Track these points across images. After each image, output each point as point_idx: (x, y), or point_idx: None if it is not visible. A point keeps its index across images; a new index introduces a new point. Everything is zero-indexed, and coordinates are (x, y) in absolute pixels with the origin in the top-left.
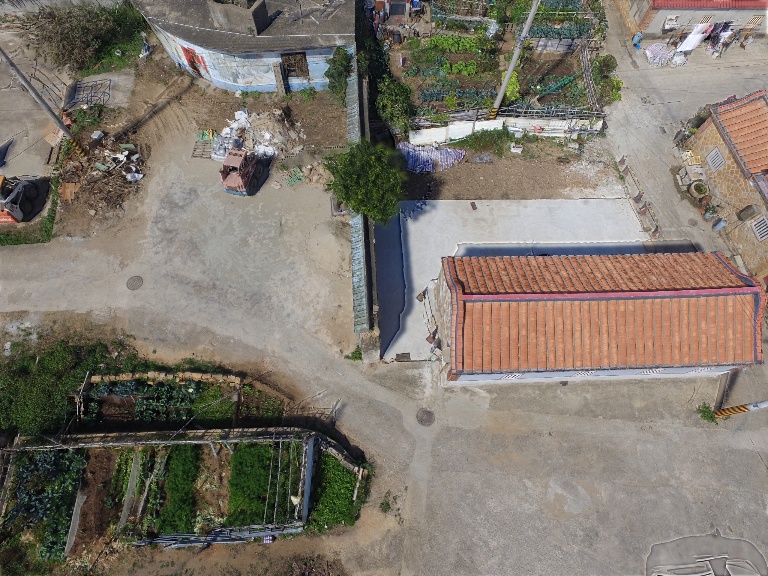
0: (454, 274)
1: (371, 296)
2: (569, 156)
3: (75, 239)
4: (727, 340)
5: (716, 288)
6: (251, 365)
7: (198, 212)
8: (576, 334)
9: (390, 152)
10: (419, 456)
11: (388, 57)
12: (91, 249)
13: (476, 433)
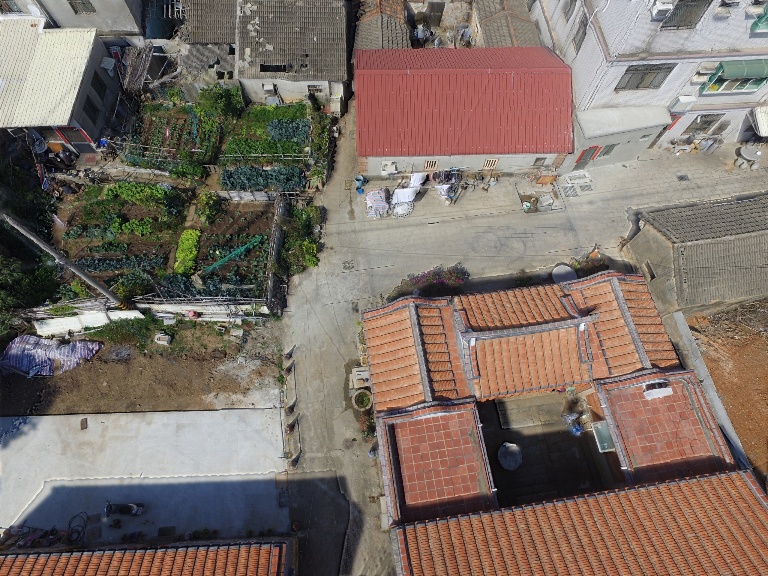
0: None
1: None
2: (227, 348)
3: None
4: None
5: None
6: None
7: None
8: None
9: None
10: None
11: (55, 212)
12: None
13: None
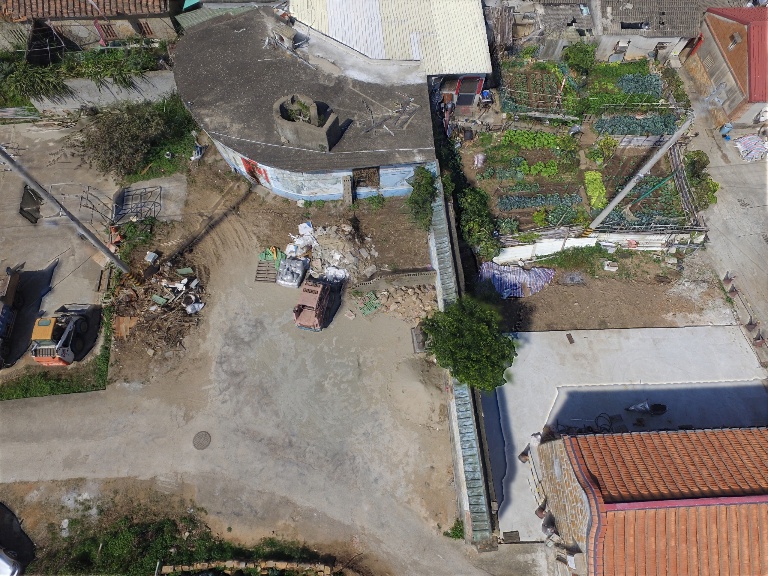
0: (583, 464)
1: (487, 489)
2: (668, 274)
3: (133, 386)
4: None
5: None
6: (339, 546)
7: (266, 349)
8: (732, 543)
9: (479, 283)
10: None
11: (459, 156)
12: (151, 398)
13: None
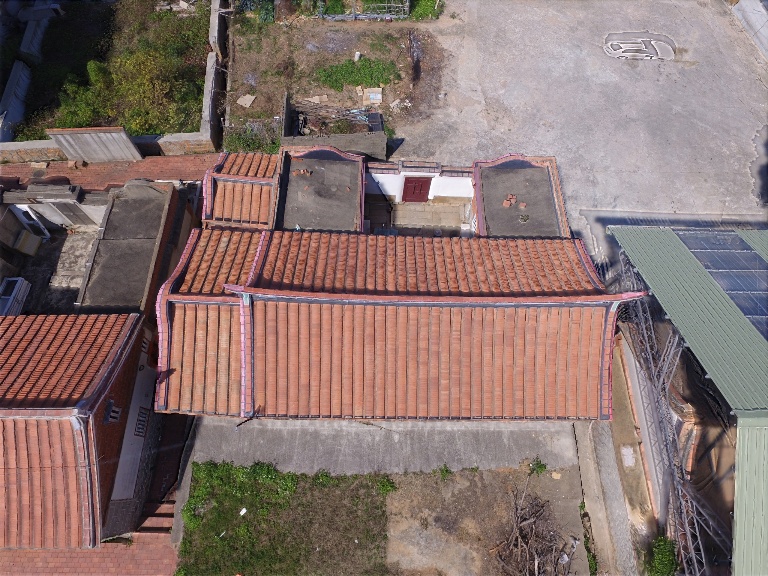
0: None
1: None
2: None
3: None
4: None
5: None
6: None
7: None
8: None
9: None
10: None
11: None
12: None
13: None
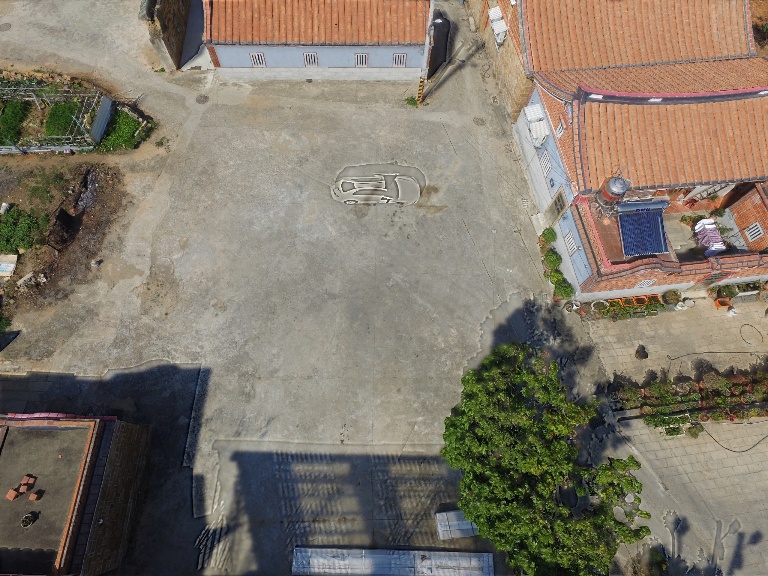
0: None
1: (156, 0)
2: None
3: None
4: (405, 26)
5: None
6: (83, 74)
7: None
8: (295, 18)
9: None
10: (192, 119)
11: None
12: None
13: (236, 107)
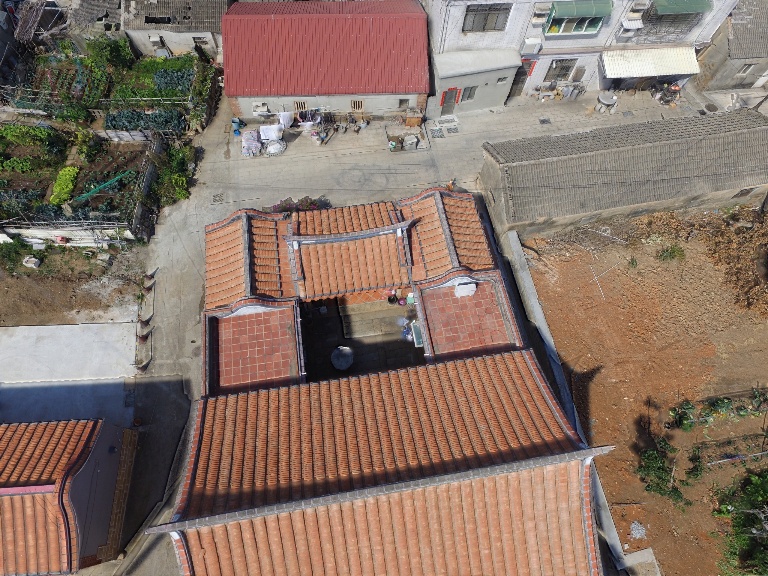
0: None
1: None
2: (93, 270)
3: None
4: (27, 547)
5: (17, 484)
6: None
7: None
8: None
9: None
10: None
11: None
12: None
13: None
